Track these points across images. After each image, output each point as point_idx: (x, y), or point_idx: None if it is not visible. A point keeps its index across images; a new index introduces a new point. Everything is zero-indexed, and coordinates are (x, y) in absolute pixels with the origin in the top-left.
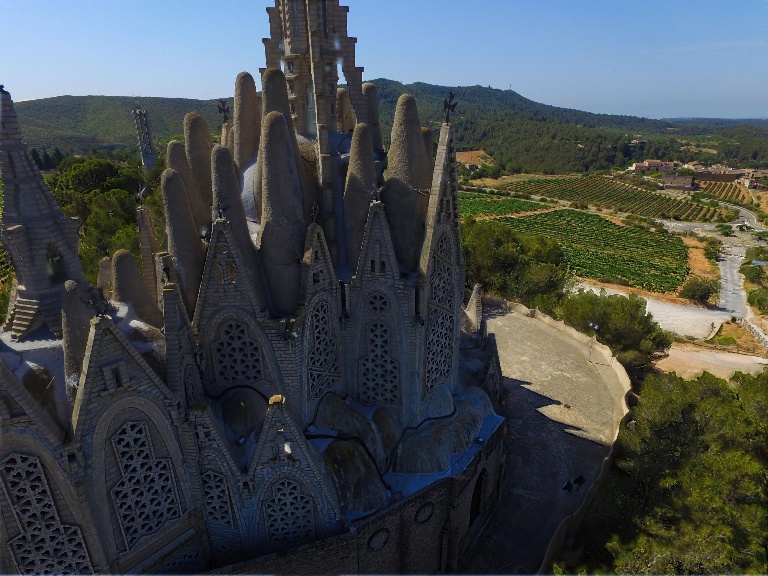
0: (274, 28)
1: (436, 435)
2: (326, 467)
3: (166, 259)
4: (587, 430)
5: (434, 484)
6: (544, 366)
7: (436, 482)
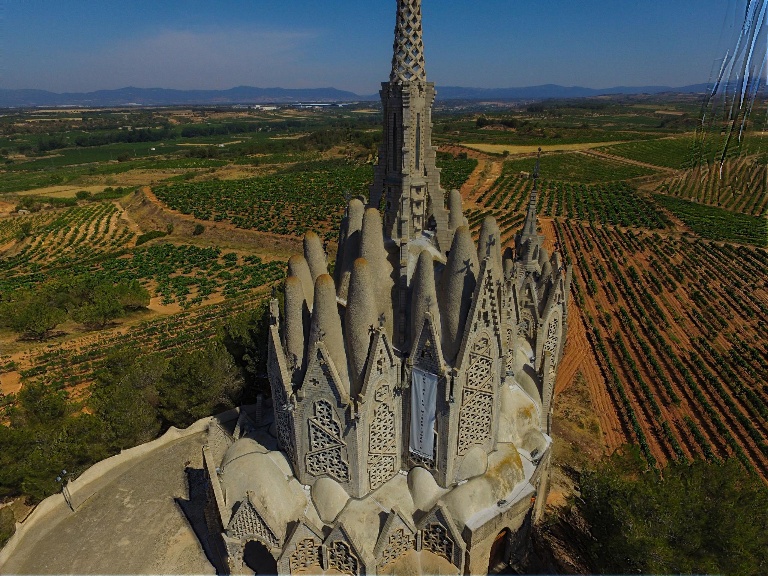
0: (432, 160)
1: None
2: None
3: None
4: (206, 442)
5: None
6: (127, 520)
7: None
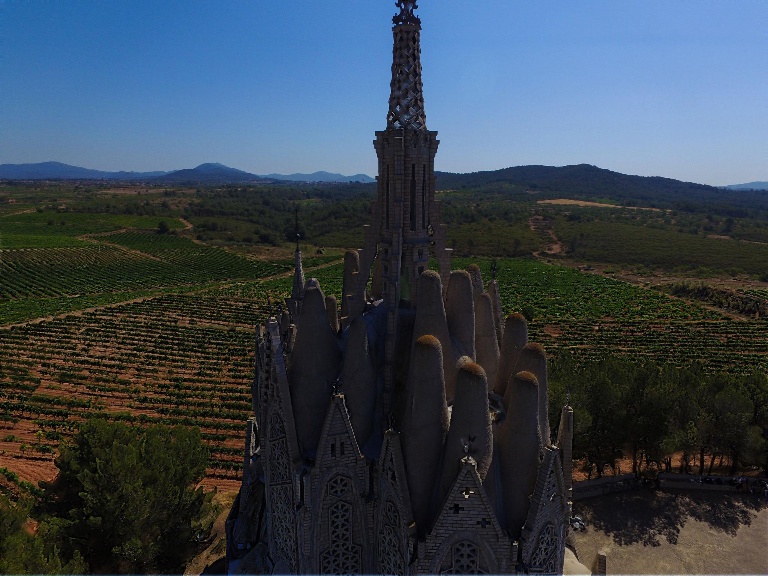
0: None
1: (251, 567)
2: (251, 484)
3: (285, 331)
4: None
5: (226, 573)
6: None
7: (226, 575)
